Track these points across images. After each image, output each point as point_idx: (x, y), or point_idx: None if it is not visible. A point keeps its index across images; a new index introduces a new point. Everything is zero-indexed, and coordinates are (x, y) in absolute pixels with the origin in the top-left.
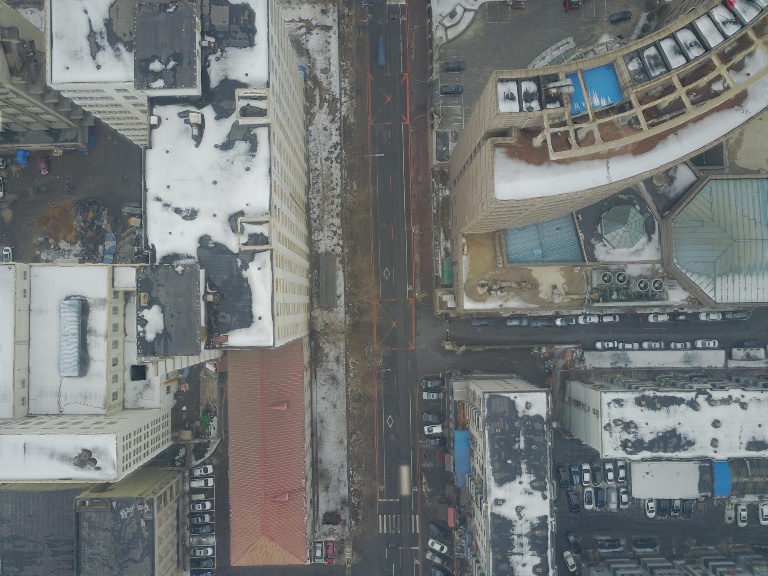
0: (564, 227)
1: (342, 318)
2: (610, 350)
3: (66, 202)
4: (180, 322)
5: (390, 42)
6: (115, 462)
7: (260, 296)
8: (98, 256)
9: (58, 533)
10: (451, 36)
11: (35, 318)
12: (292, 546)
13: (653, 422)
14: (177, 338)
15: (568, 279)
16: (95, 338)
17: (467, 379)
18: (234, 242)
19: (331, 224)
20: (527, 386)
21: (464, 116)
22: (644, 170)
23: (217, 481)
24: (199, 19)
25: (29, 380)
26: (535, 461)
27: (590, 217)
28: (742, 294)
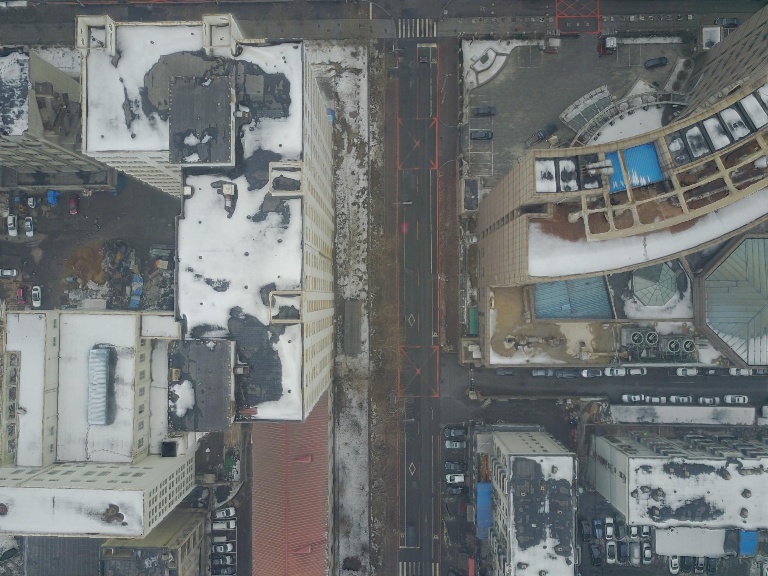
0: (594, 282)
1: (366, 364)
2: (637, 404)
3: (94, 242)
4: (211, 398)
5: (420, 86)
6: (142, 518)
7: (290, 369)
8: (125, 297)
9: None
10: (482, 81)
11: (64, 365)
12: None
13: (682, 490)
14: (208, 414)
15: (597, 336)
16: (122, 386)
17: (491, 431)
18: (265, 314)
19: (357, 269)
20: (553, 445)
21: (493, 162)
22: (682, 248)
23: (239, 523)
24: (234, 88)
25: (57, 426)
26: (560, 526)
27: None
28: None
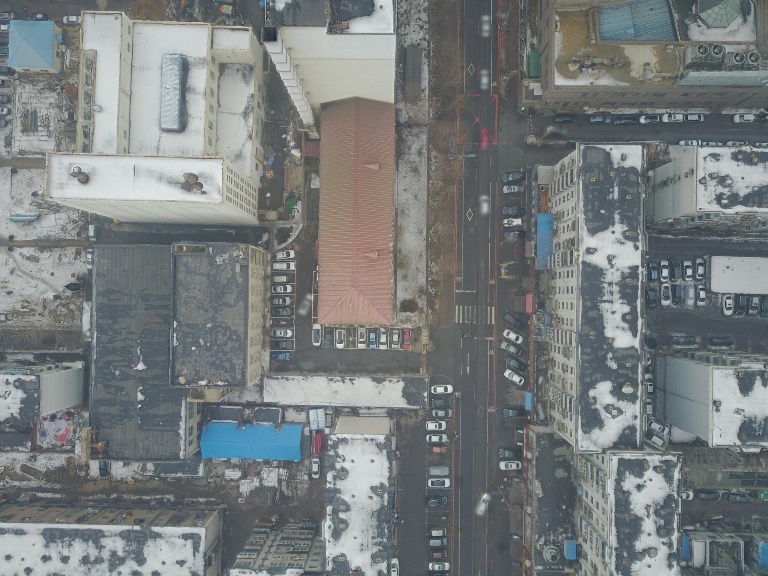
0: (658, 8)
1: (426, 111)
2: None
3: None
4: None
5: None
6: (220, 187)
7: None
8: None
9: (151, 288)
10: None
11: (137, 74)
12: (379, 304)
13: (749, 177)
14: (305, 8)
15: (660, 58)
16: (194, 95)
17: None
18: None
19: (418, 18)
20: None
21: None
22: None
23: (298, 266)
24: None
25: (130, 134)
26: (628, 212)
27: None
28: None
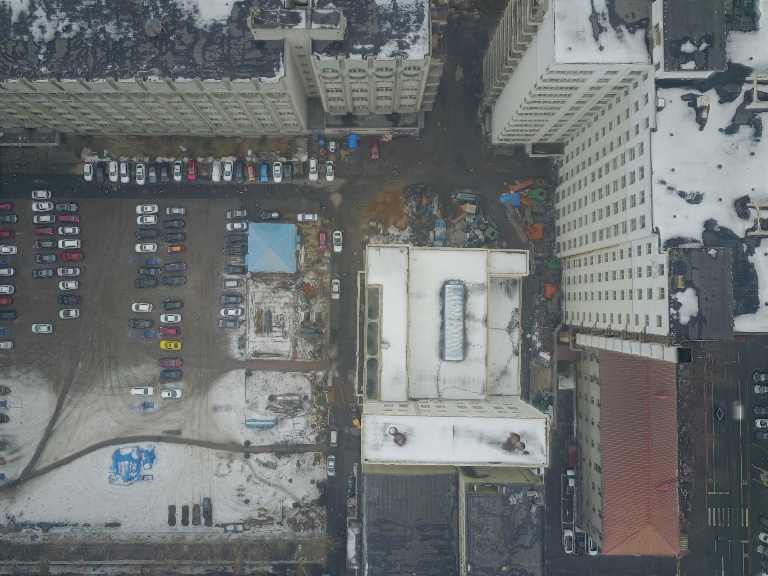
0: None
1: None
2: None
3: (395, 187)
4: (714, 305)
5: None
6: (544, 447)
7: (767, 282)
8: (428, 242)
9: (426, 517)
10: None
11: (414, 301)
12: (670, 536)
13: None
14: (712, 321)
15: None
16: (474, 323)
17: None
18: (740, 227)
19: None
20: None
21: None
22: None
23: (547, 470)
24: None
25: None
26: None
27: None
28: None
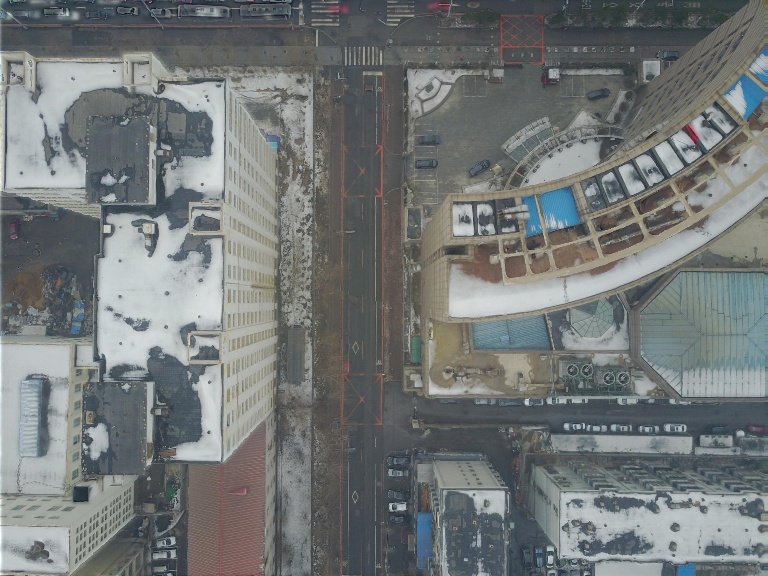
0: None
1: (309, 392)
2: (577, 433)
3: (35, 267)
4: (125, 441)
5: (365, 114)
6: (68, 555)
7: (209, 410)
8: (66, 323)
9: None
10: (427, 109)
11: None
12: None
13: (612, 524)
14: (122, 457)
15: (535, 367)
16: (56, 417)
17: (432, 460)
18: (185, 354)
19: (301, 297)
20: (489, 477)
21: (438, 191)
22: (602, 290)
23: (180, 553)
24: (155, 126)
25: None
26: (492, 560)
27: None
28: (709, 389)
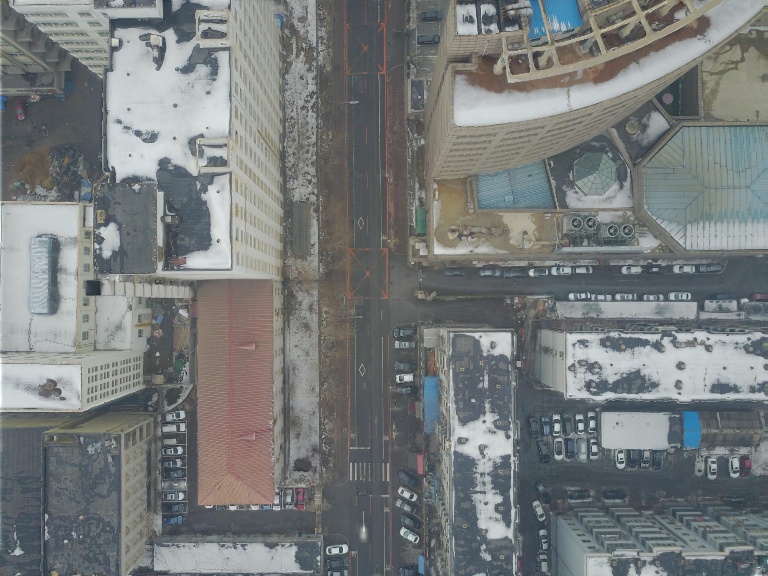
0: (536, 174)
1: (316, 266)
2: (582, 300)
3: (42, 148)
4: (136, 240)
5: None
6: (80, 392)
7: (219, 219)
8: None
9: (28, 470)
10: None
11: (6, 256)
12: (259, 485)
13: (618, 363)
14: (133, 256)
15: (539, 226)
16: (65, 276)
17: (438, 327)
18: (193, 165)
19: (306, 173)
20: None
21: None
22: (605, 99)
23: (189, 427)
24: None
25: None
26: (499, 400)
27: (562, 164)
28: (712, 241)
